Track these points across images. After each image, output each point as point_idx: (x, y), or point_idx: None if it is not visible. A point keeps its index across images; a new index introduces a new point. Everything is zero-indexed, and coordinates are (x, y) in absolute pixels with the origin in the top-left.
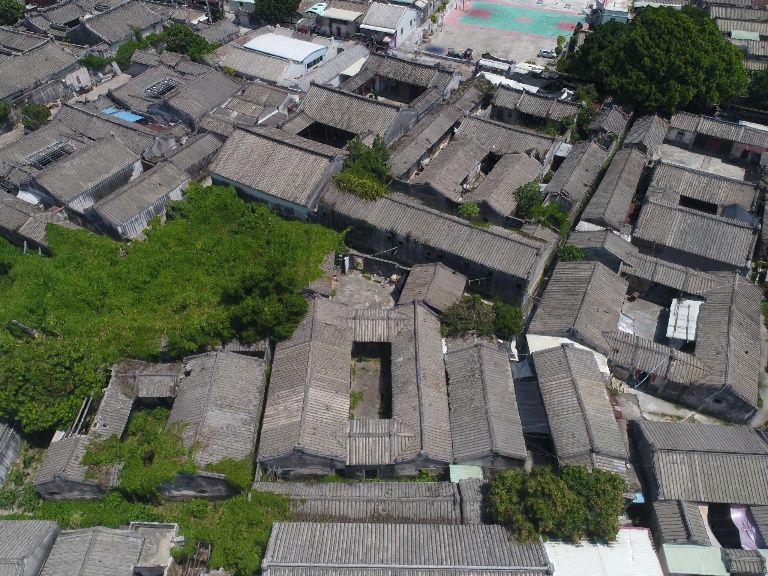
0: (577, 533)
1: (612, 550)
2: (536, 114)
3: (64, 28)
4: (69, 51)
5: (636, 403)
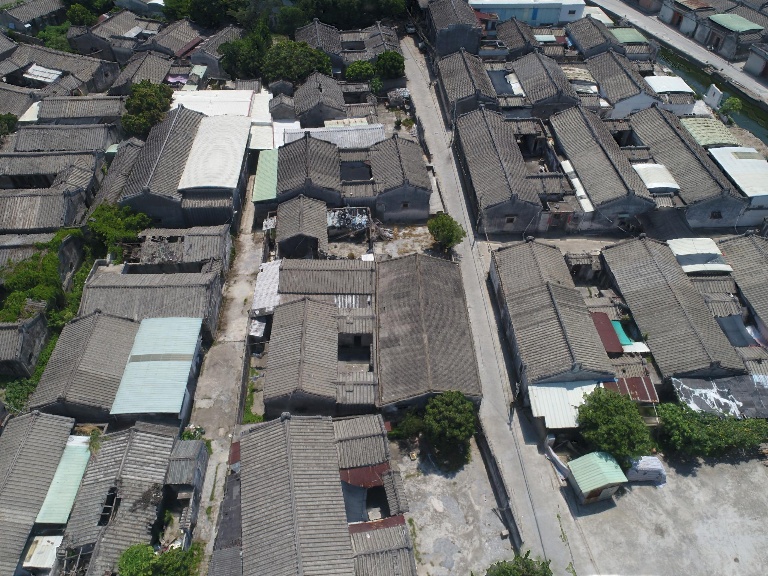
0: (166, 100)
1: (177, 99)
2: None
3: None
4: None
5: (95, 94)
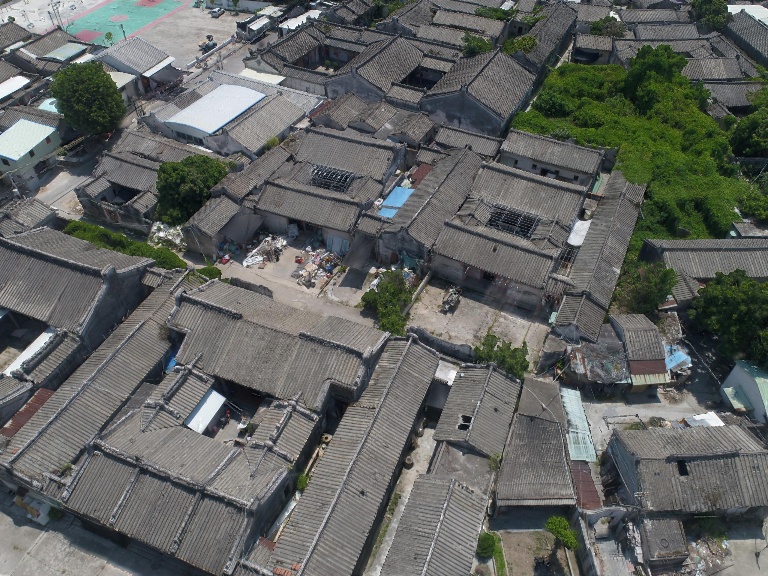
0: None
1: None
2: (366, 10)
3: (55, 341)
4: (206, 284)
5: None
